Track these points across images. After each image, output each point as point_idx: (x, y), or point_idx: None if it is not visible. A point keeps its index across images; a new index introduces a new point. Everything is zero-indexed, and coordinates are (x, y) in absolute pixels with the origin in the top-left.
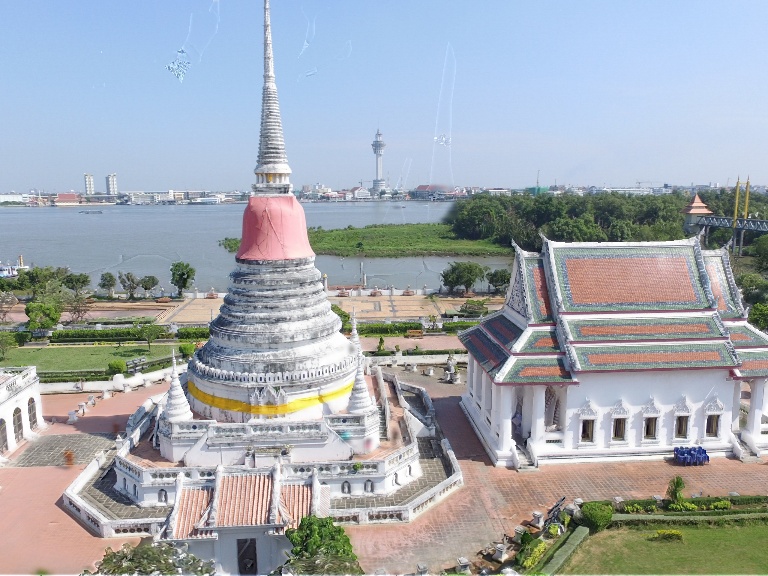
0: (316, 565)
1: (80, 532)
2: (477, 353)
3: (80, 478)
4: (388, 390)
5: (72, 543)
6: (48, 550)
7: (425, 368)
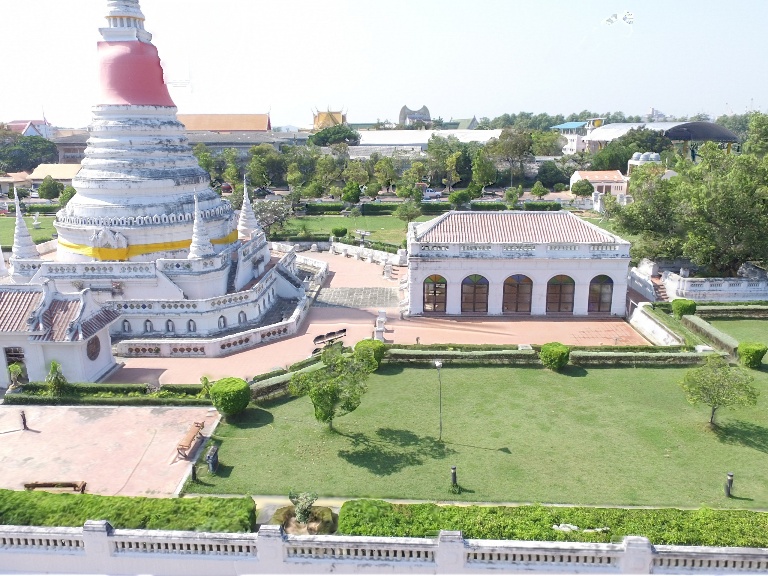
0: None
1: None
2: None
3: None
4: None
5: None
6: (323, 260)
7: None
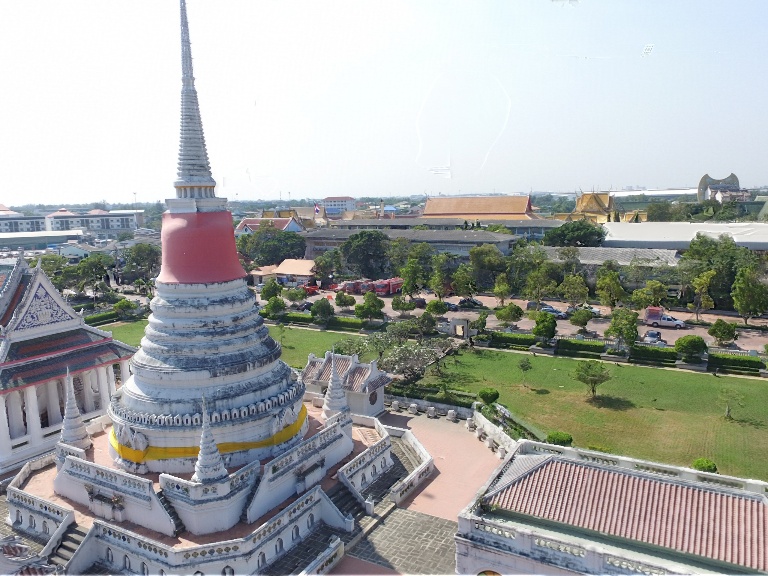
0: None
1: (425, 447)
2: (72, 368)
3: (419, 467)
4: None
5: (431, 442)
6: (446, 442)
7: None
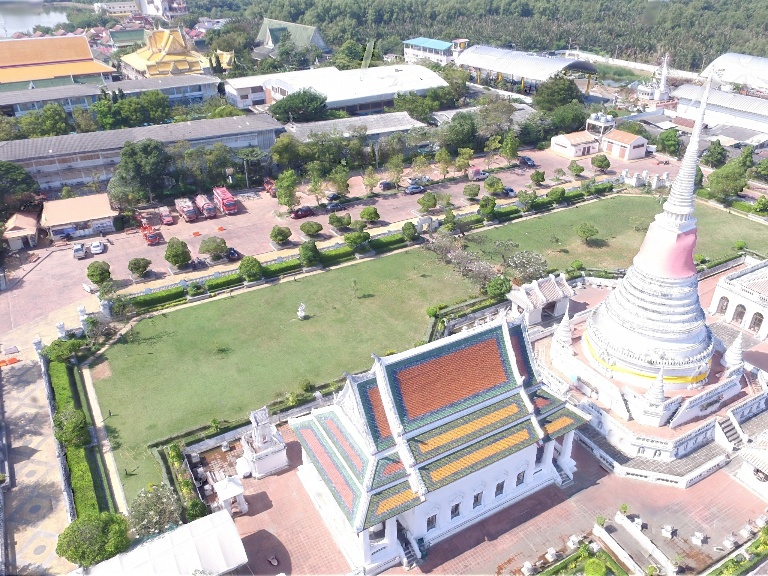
0: (487, 269)
1: None
2: None
3: None
4: (623, 424)
5: None
6: None
7: (696, 556)
